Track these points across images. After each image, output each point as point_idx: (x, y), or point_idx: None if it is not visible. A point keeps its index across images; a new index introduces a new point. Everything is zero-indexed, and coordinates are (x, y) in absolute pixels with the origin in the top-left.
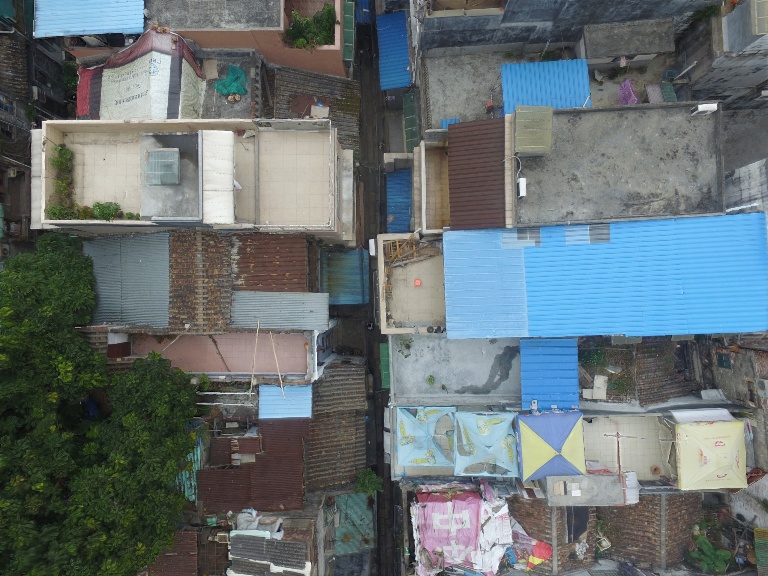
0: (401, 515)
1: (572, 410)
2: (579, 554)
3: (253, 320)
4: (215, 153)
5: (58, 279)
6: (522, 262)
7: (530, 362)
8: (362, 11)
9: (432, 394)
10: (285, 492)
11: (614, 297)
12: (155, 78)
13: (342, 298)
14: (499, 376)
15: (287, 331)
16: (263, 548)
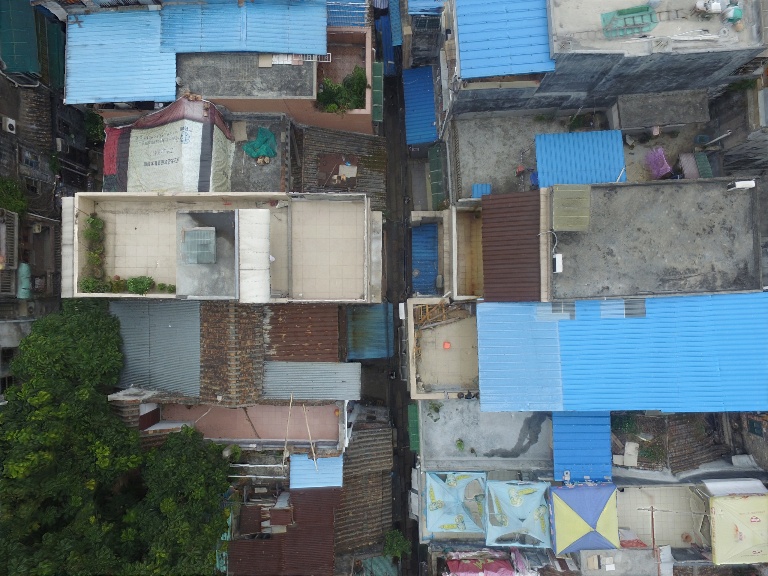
0: (426, 571)
1: (605, 482)
2: None
3: (285, 391)
4: (252, 232)
5: (86, 343)
6: (556, 335)
7: (562, 432)
8: (387, 63)
9: (461, 457)
10: (316, 562)
11: (650, 372)
12: (187, 146)
13: (367, 352)
14: (528, 439)
15: (320, 403)
16: None
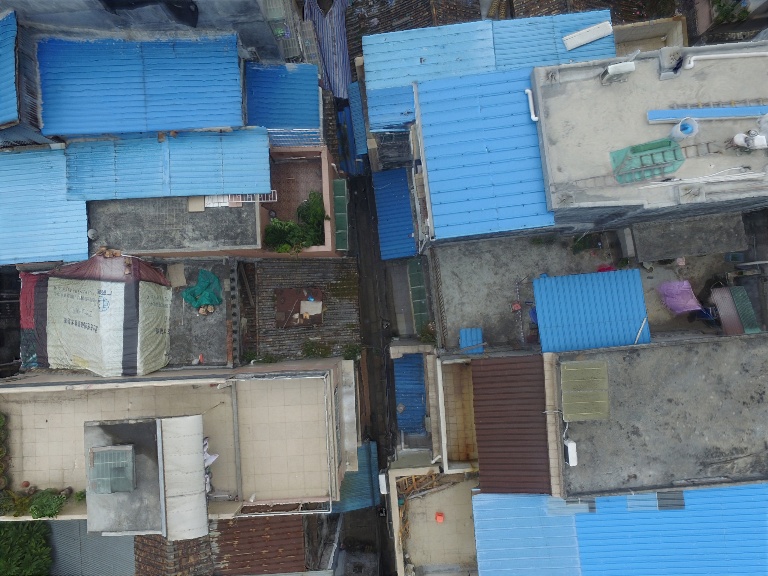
0: None
1: None
2: None
3: None
4: (179, 447)
5: (3, 545)
6: (574, 533)
7: None
8: (355, 161)
9: None
10: None
11: None
12: (106, 313)
13: (348, 504)
14: None
15: None
16: None
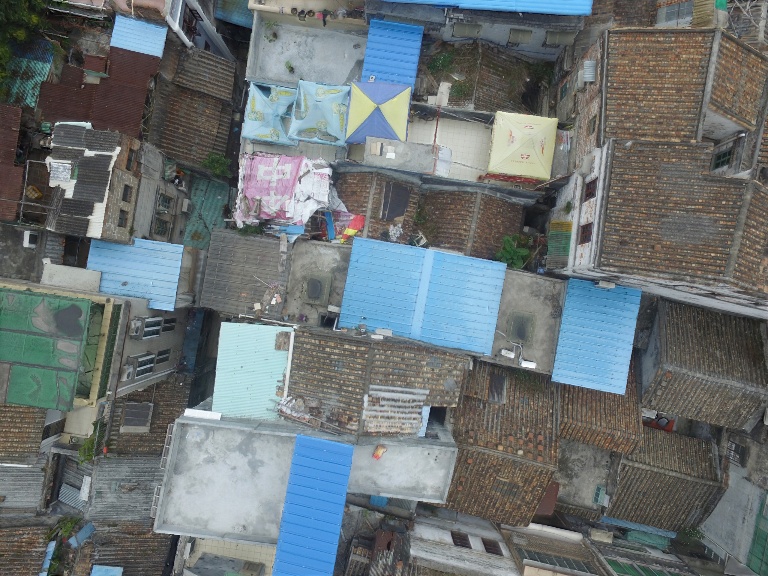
0: None
1: None
2: (392, 235)
3: None
4: None
5: None
6: None
7: (376, 41)
8: None
9: None
10: (123, 120)
11: None
12: None
13: (235, 17)
14: (356, 80)
15: None
16: (82, 136)
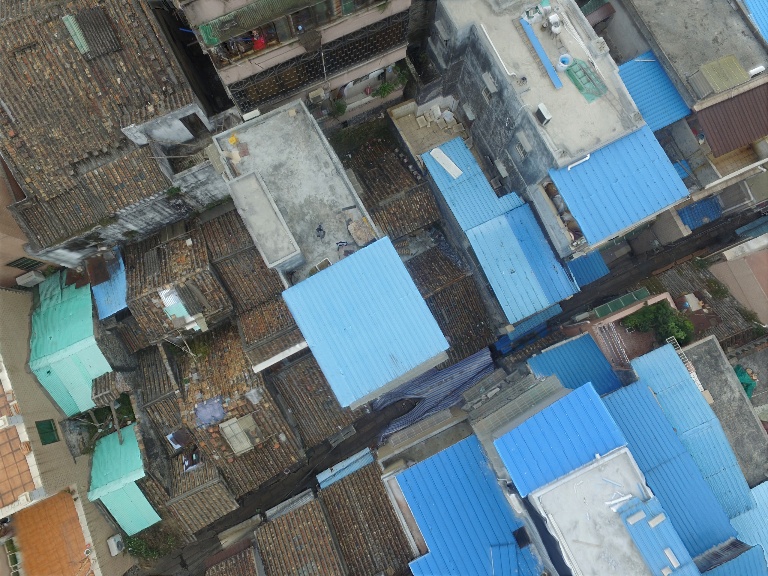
0: None
1: None
2: None
3: None
4: None
5: None
6: None
7: None
8: None
9: None
10: None
11: None
12: None
13: None
14: None
15: None
16: None
